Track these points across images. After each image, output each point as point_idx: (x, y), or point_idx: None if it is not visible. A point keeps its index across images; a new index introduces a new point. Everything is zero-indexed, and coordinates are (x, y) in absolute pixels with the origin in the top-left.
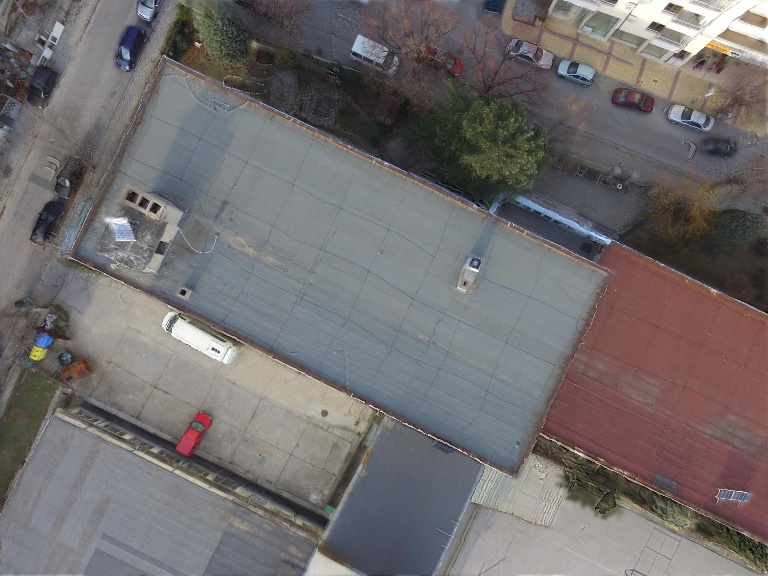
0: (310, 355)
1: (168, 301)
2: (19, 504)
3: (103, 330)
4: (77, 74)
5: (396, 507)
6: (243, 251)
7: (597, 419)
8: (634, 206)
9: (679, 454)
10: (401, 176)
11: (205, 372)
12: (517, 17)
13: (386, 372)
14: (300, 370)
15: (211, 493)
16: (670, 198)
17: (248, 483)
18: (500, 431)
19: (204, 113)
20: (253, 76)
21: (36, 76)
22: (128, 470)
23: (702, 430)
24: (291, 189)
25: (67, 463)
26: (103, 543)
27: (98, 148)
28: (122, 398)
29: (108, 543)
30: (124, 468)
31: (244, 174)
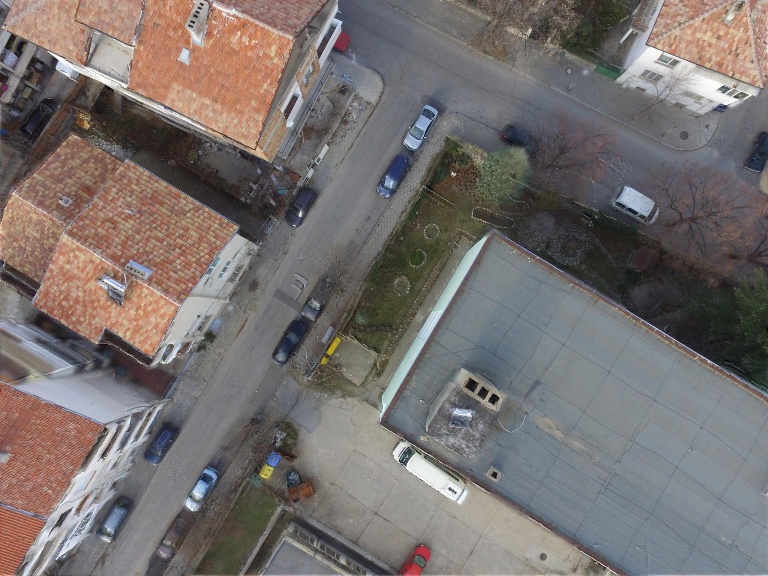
0: (613, 548)
1: (476, 480)
2: None
3: (330, 451)
4: (334, 195)
5: None
6: (551, 434)
7: None
8: None
9: None
10: (720, 375)
11: (427, 503)
12: None
13: (688, 573)
14: (604, 564)
15: None
16: None
17: None
18: None
19: (525, 291)
20: (503, 210)
21: (298, 197)
22: None
23: None
24: (606, 376)
25: None
26: None
27: (347, 271)
28: (342, 521)
29: None
30: None
31: (560, 356)
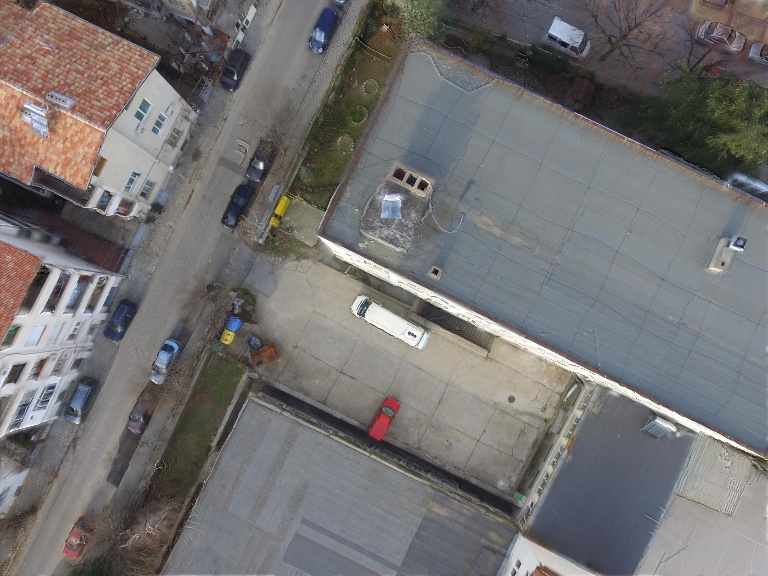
0: (561, 336)
1: (418, 281)
2: (217, 488)
3: (289, 314)
4: (268, 56)
5: (603, 493)
6: (489, 231)
7: None
8: None
9: None
10: (652, 155)
11: (391, 357)
12: None
13: (637, 353)
14: (553, 351)
15: (409, 478)
16: None
17: (436, 469)
18: (755, 414)
19: (450, 91)
20: (439, 59)
21: (231, 58)
22: (326, 454)
23: None
24: (539, 168)
25: (265, 447)
26: (303, 527)
27: (288, 131)
28: (308, 383)
29: (308, 527)
30: (322, 452)
31: (491, 153)
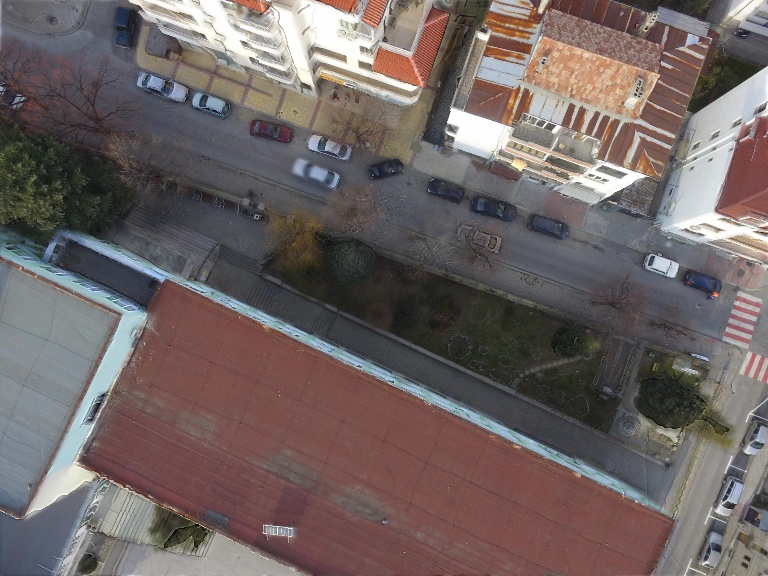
0: None
1: None
2: None
3: None
4: None
5: None
6: None
7: (154, 456)
8: (276, 236)
9: (233, 490)
10: None
11: None
12: (150, 51)
13: None
14: None
15: None
16: (306, 228)
17: None
18: (14, 474)
19: None
20: None
21: None
22: None
23: (259, 465)
24: None
25: None
26: None
27: None
28: None
29: None
30: None
31: None
